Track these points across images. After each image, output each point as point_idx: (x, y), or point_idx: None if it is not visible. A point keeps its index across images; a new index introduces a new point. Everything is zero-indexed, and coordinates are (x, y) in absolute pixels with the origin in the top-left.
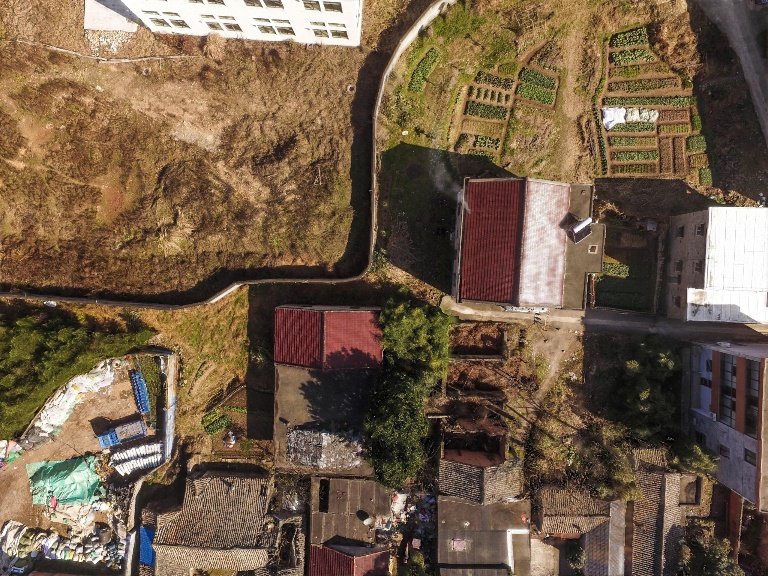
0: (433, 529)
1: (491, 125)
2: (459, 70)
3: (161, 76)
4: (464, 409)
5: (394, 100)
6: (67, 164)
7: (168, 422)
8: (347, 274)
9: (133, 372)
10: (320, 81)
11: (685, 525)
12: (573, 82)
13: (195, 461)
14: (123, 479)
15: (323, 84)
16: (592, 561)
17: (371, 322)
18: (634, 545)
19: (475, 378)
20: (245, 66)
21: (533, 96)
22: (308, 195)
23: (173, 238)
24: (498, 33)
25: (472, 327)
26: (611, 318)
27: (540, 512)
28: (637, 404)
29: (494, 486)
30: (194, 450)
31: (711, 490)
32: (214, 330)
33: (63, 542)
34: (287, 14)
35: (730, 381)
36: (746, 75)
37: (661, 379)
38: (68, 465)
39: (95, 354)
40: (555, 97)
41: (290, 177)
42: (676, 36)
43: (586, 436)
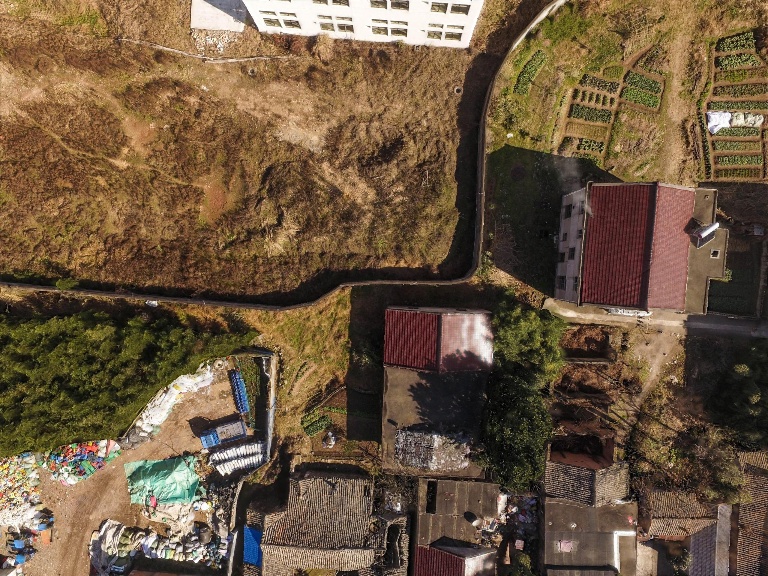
0: (534, 530)
1: (595, 128)
2: (565, 73)
3: (267, 76)
4: (565, 411)
5: (502, 102)
6: (171, 164)
7: (270, 422)
8: (450, 276)
9: (233, 372)
10: (427, 83)
11: None
12: (678, 86)
13: (296, 461)
14: (223, 479)
15: (430, 86)
16: (697, 563)
17: (483, 325)
18: (739, 547)
19: (577, 381)
20: (352, 67)
21: (638, 99)
22: (416, 197)
23: (279, 239)
24: (605, 36)
25: (576, 330)
26: (713, 322)
27: (646, 514)
28: (746, 408)
29: (604, 488)
30: (295, 450)
31: None
32: (315, 331)
33: (163, 541)
34: (409, 16)
35: None
36: None
37: None
38: (167, 465)
39: (203, 354)
40: (660, 101)
41: (397, 179)
42: None
43: (687, 439)
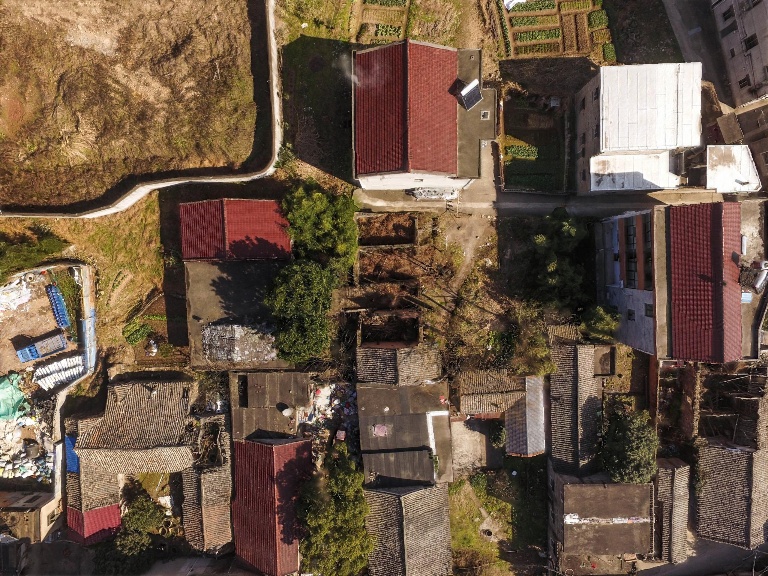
0: None
1: (392, 13)
2: None
3: None
4: (382, 302)
5: None
6: None
7: (87, 333)
8: None
9: (49, 287)
10: None
11: (605, 400)
12: None
13: (117, 371)
14: (47, 393)
15: None
16: (512, 438)
17: (276, 212)
18: (553, 419)
19: (390, 269)
20: None
21: None
22: (208, 91)
23: (75, 144)
24: None
25: (384, 217)
26: (522, 200)
27: (458, 393)
28: (546, 278)
29: (409, 368)
30: (116, 360)
31: (630, 365)
32: (127, 239)
33: None
34: None
35: (632, 244)
36: None
37: (567, 250)
38: None
39: (2, 264)
40: None
41: (189, 75)
42: None
43: (504, 320)
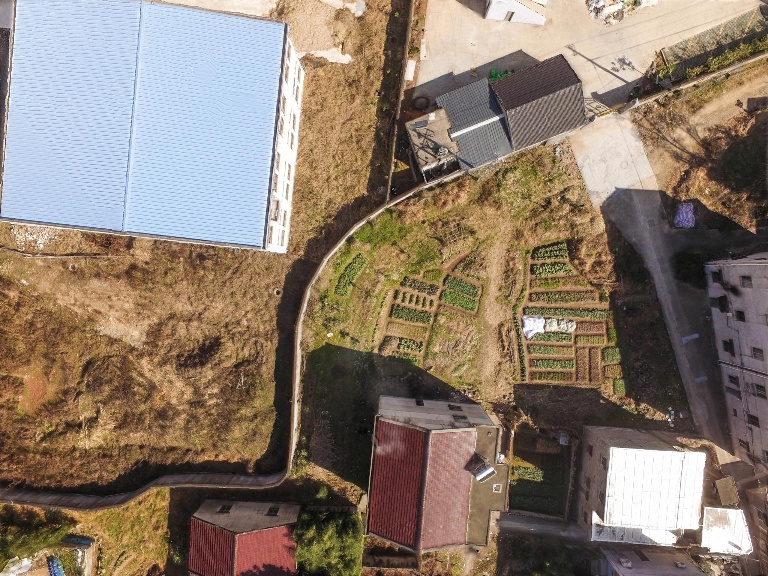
0: None
1: (415, 329)
2: (385, 276)
3: (88, 272)
4: None
5: (319, 308)
6: None
7: None
8: (269, 470)
9: (51, 560)
10: (247, 284)
11: None
12: (495, 291)
13: None
14: None
15: (250, 287)
16: None
17: (285, 536)
18: None
19: None
20: (173, 266)
21: (457, 303)
22: (230, 400)
23: (93, 437)
24: (424, 242)
25: None
26: (525, 521)
27: None
28: None
29: None
30: None
31: None
32: (134, 521)
33: None
34: None
35: None
36: (659, 294)
37: None
38: None
39: (8, 556)
40: (478, 304)
41: (213, 380)
42: (594, 254)
43: None
